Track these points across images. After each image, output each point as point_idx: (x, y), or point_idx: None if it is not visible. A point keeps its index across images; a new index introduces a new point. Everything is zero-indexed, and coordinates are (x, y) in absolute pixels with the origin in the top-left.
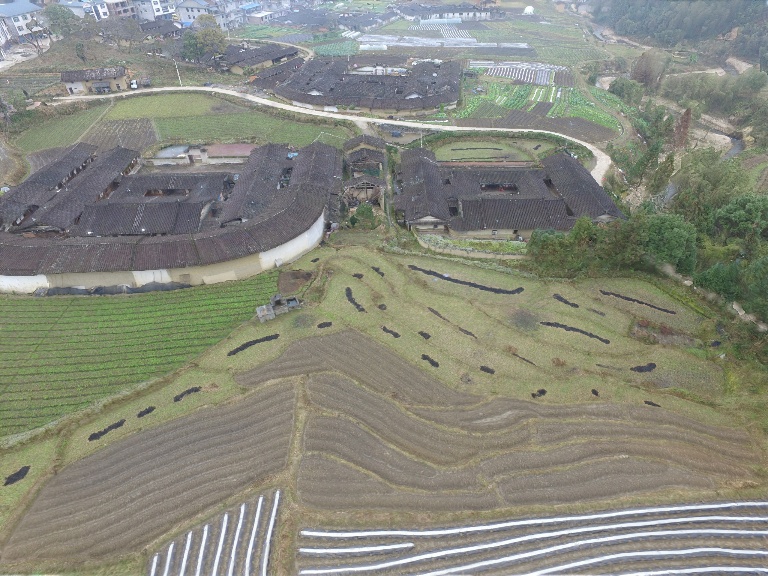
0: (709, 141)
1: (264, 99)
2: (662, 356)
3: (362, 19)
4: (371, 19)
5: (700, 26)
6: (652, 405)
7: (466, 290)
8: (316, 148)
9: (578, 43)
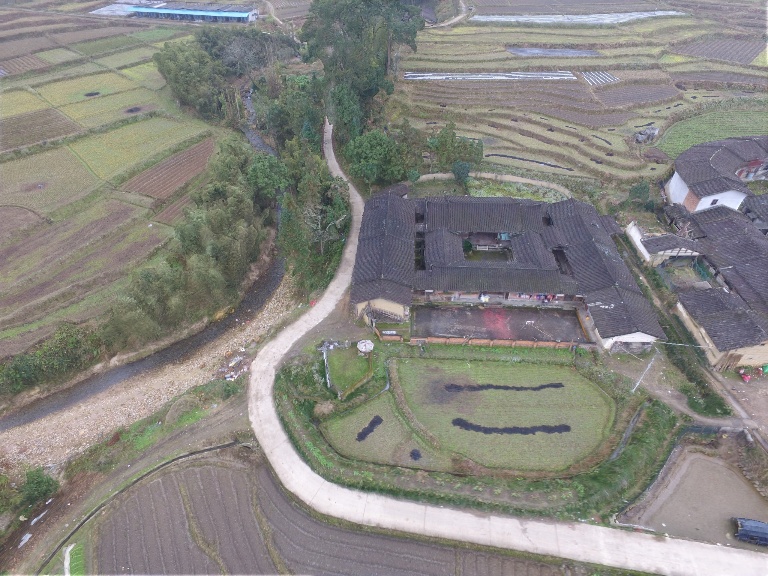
0: None
1: None
2: (420, 126)
3: None
4: None
5: None
6: (443, 106)
7: (526, 156)
8: None
9: None
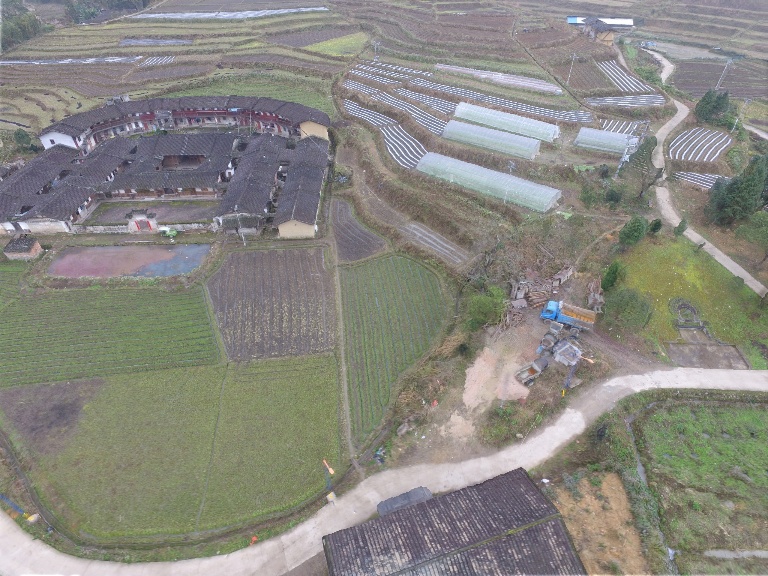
0: None
1: None
2: None
3: None
4: None
5: None
6: None
7: None
8: None
9: None
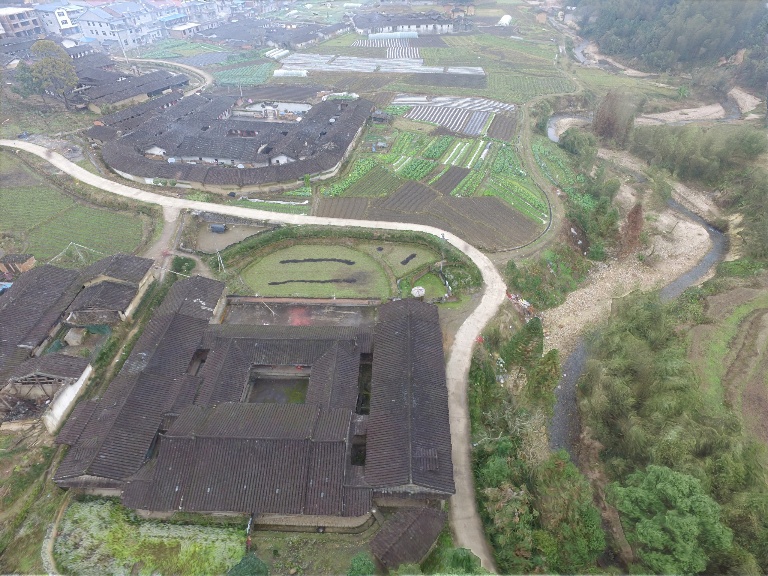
0: (677, 238)
1: (72, 164)
2: None
3: (300, 33)
4: (311, 33)
5: (698, 46)
6: None
7: None
8: (33, 280)
9: (544, 67)
